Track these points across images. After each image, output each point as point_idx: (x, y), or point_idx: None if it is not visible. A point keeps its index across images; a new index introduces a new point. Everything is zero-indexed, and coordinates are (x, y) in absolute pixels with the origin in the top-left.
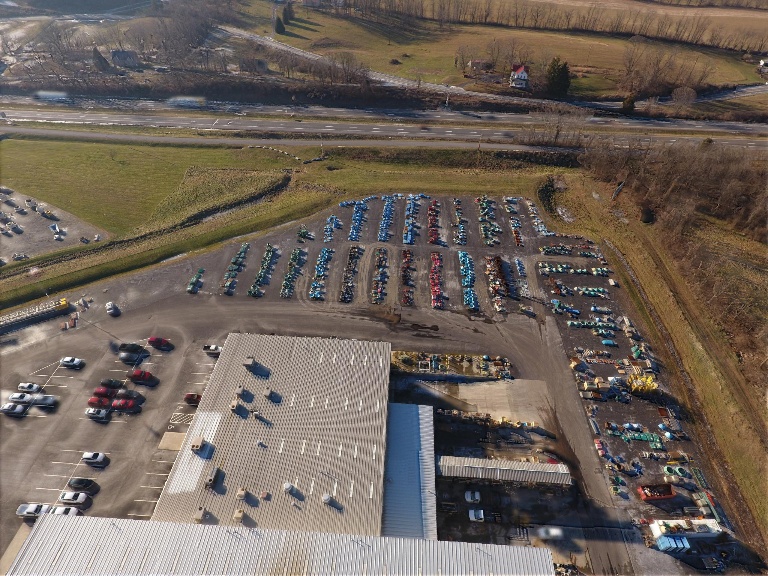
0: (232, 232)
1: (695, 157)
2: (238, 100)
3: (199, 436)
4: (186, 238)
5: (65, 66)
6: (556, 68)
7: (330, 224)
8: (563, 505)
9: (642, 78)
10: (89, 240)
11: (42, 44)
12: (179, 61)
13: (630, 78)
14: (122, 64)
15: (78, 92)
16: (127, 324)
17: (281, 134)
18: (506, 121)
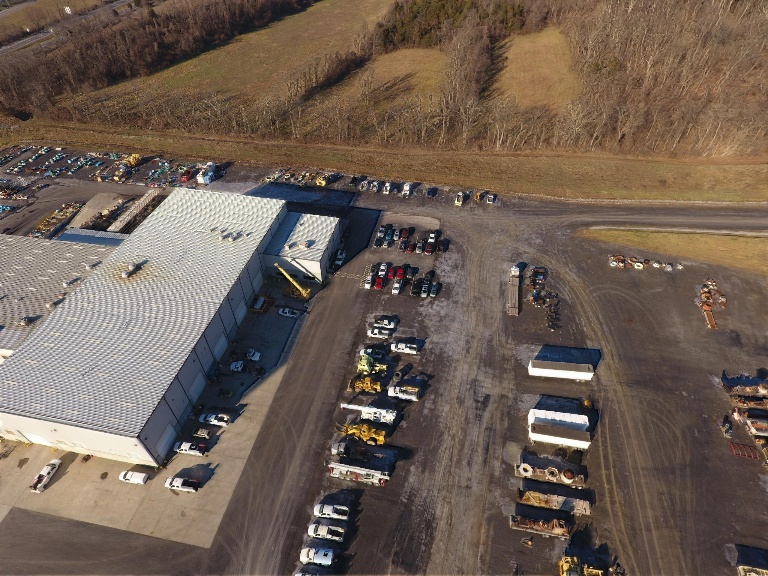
0: None
1: None
2: None
3: None
4: None
5: None
6: None
7: None
8: None
9: None
10: None
11: None
12: None
13: None
14: None
15: None
16: None
17: None
18: None
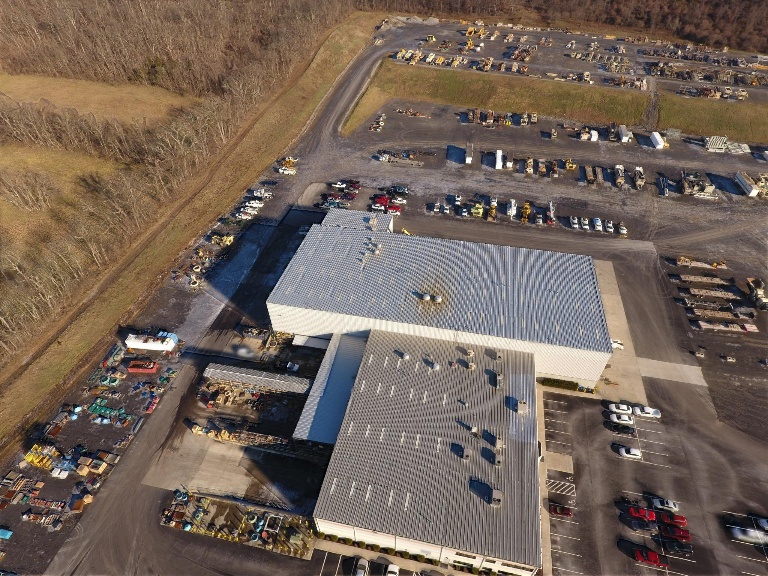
0: None
1: None
2: None
3: (524, 417)
4: None
5: None
6: None
7: None
8: None
9: None
10: None
11: None
12: None
13: None
14: None
15: None
16: None
17: None
18: None
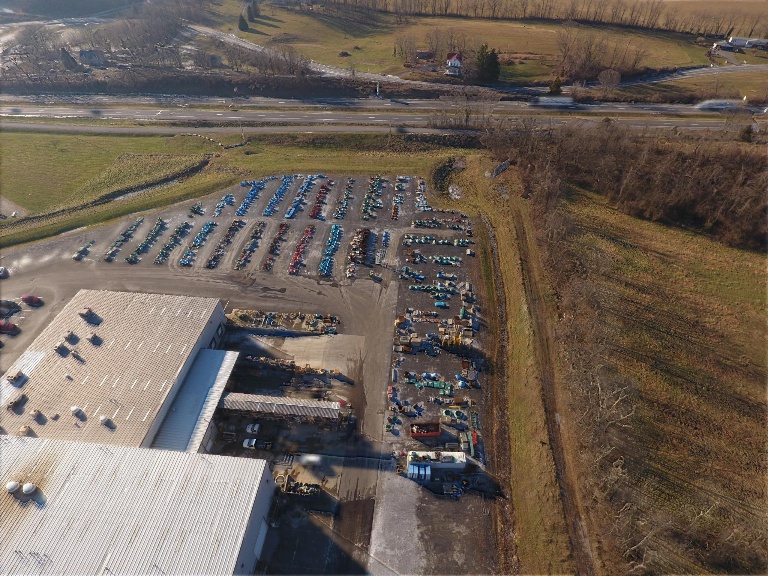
0: (132, 208)
1: (579, 135)
2: (186, 93)
3: None
4: (89, 214)
5: (38, 66)
6: (484, 55)
7: (224, 201)
8: (335, 438)
9: (573, 63)
10: (7, 216)
11: (27, 47)
12: (143, 59)
13: (563, 63)
14: (89, 63)
15: (44, 89)
16: (11, 285)
17: (212, 123)
18: (431, 107)
